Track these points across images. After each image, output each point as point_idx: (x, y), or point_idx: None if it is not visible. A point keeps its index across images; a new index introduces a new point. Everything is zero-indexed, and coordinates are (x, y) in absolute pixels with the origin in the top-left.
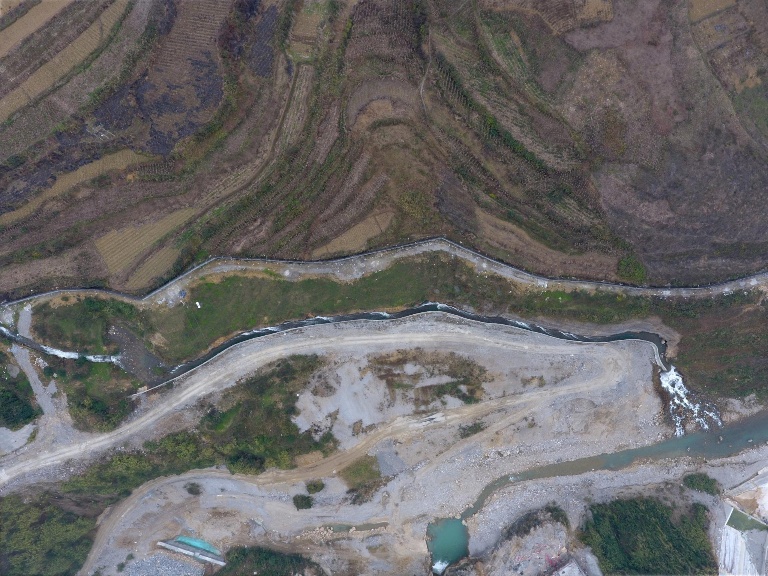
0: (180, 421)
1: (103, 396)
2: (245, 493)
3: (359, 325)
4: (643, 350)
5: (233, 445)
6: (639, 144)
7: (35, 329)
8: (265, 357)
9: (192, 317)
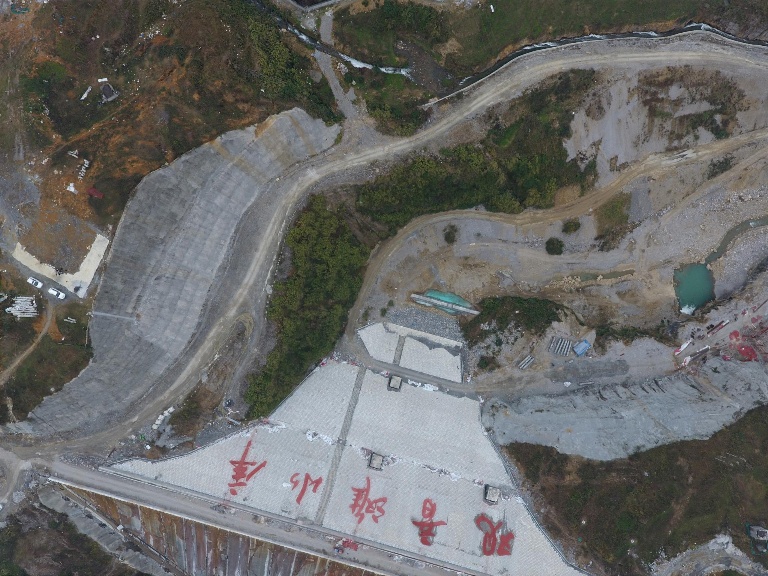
0: (469, 133)
1: (398, 105)
2: (499, 239)
3: (631, 43)
4: None
5: (517, 159)
6: None
7: (336, 34)
8: (547, 70)
9: (486, 21)
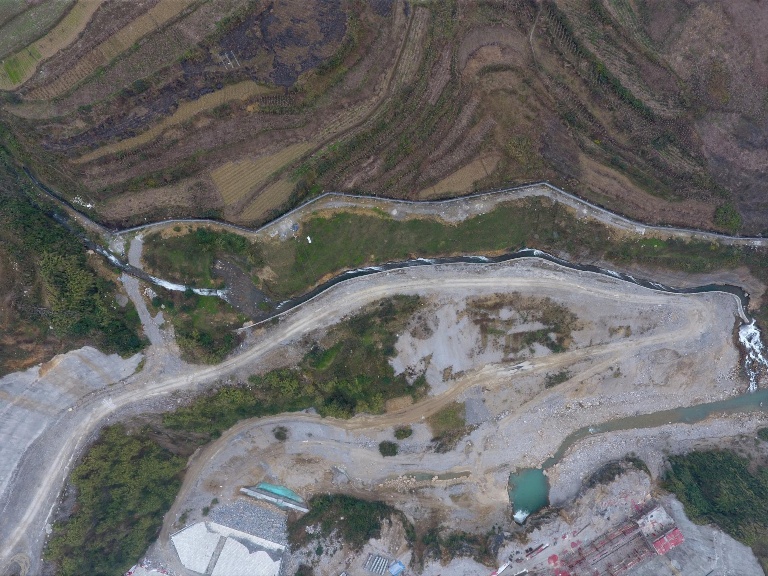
0: (284, 357)
1: (209, 329)
2: (332, 439)
3: (459, 268)
4: (727, 302)
5: (334, 383)
6: (742, 94)
7: (146, 259)
8: (369, 296)
9: (302, 251)
